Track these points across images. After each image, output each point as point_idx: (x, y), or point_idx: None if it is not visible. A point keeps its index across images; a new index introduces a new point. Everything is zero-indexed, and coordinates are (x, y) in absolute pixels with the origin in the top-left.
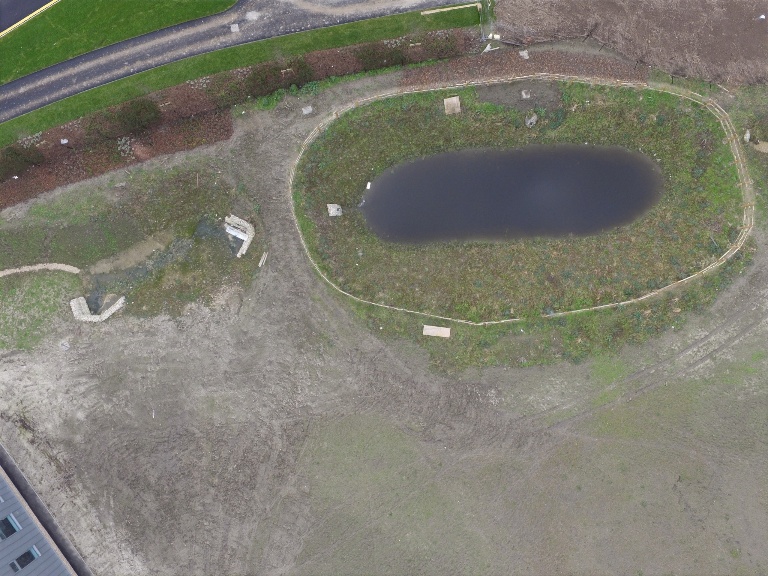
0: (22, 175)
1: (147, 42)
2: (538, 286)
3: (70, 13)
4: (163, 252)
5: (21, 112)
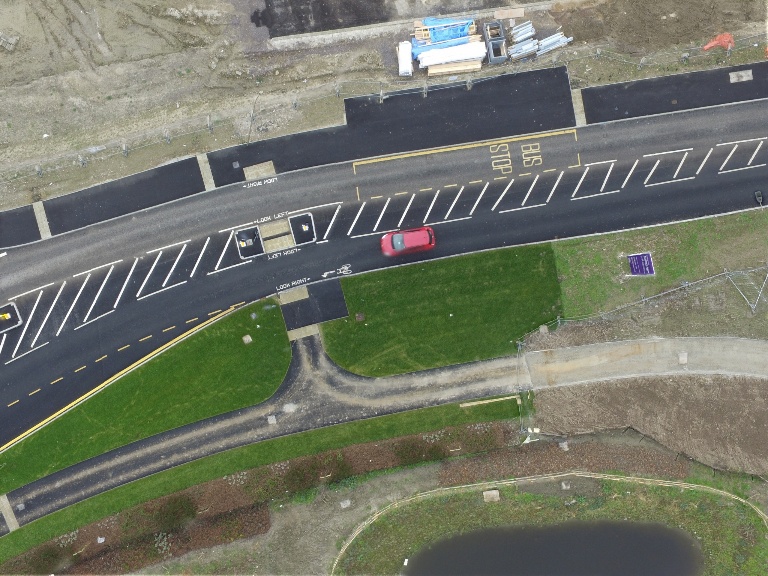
0: (58, 573)
1: (184, 435)
2: None
3: (106, 407)
4: None
5: (57, 507)
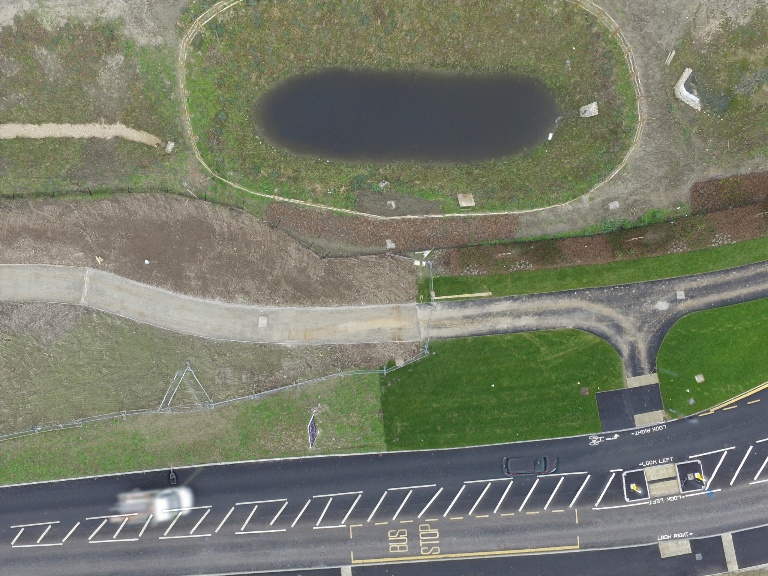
0: None
1: None
2: (396, 8)
3: None
4: (765, 83)
5: None
